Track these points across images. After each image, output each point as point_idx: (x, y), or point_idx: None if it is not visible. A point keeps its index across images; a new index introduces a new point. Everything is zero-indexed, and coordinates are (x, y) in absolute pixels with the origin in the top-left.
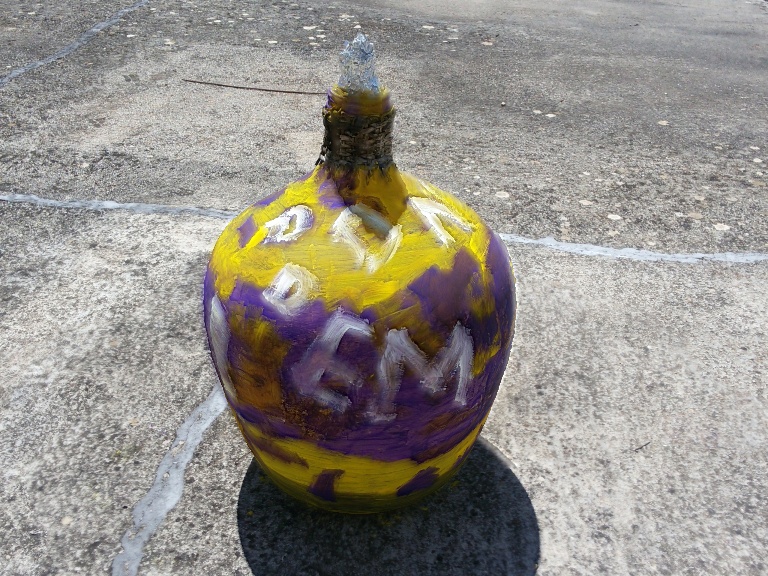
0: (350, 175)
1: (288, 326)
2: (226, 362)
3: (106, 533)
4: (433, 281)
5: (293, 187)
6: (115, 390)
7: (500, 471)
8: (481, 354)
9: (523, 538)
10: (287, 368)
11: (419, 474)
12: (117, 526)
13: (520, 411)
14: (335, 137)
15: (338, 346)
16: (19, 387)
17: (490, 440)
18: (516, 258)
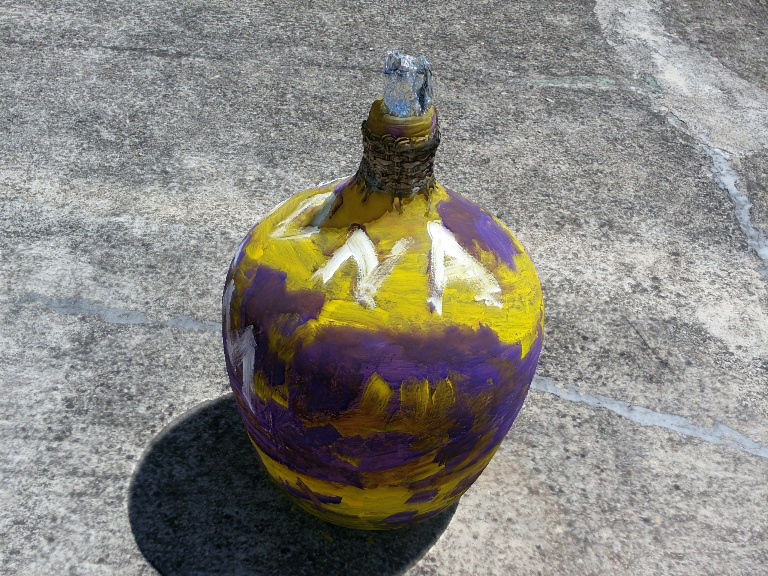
0: None
1: None
2: None
3: None
4: (269, 279)
5: None
6: None
7: None
8: (262, 380)
9: None
10: None
11: None
12: None
13: None
14: None
15: None
16: None
17: None
18: None
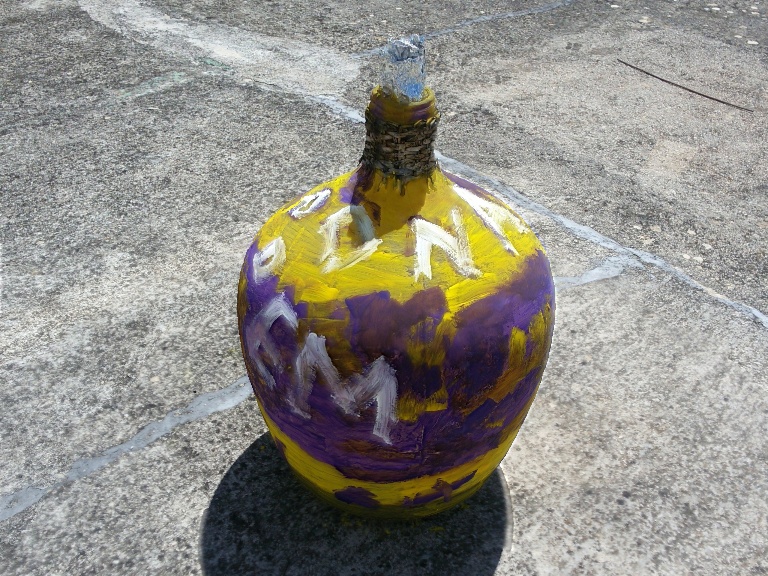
0: (368, 176)
1: (251, 291)
2: None
3: (165, 402)
4: (373, 306)
5: None
6: None
7: (491, 545)
8: (410, 402)
9: None
10: None
11: (351, 489)
12: (176, 402)
13: (578, 505)
14: None
15: (271, 326)
16: (226, 270)
17: (516, 513)
18: (766, 358)
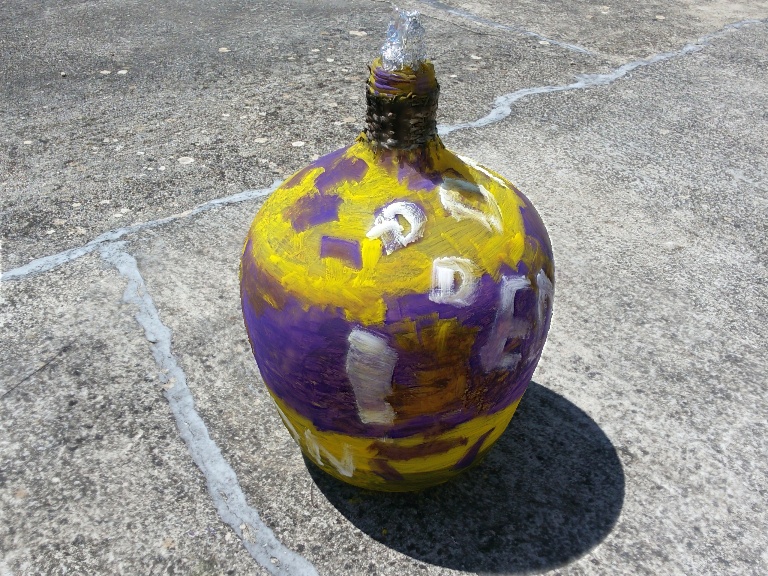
0: (425, 156)
1: (470, 316)
2: (385, 390)
3: None
4: (531, 221)
5: (352, 192)
6: (100, 533)
7: None
8: None
9: (562, 408)
10: (475, 356)
11: None
12: None
13: None
14: (401, 124)
15: (514, 311)
16: None
17: None
18: None
